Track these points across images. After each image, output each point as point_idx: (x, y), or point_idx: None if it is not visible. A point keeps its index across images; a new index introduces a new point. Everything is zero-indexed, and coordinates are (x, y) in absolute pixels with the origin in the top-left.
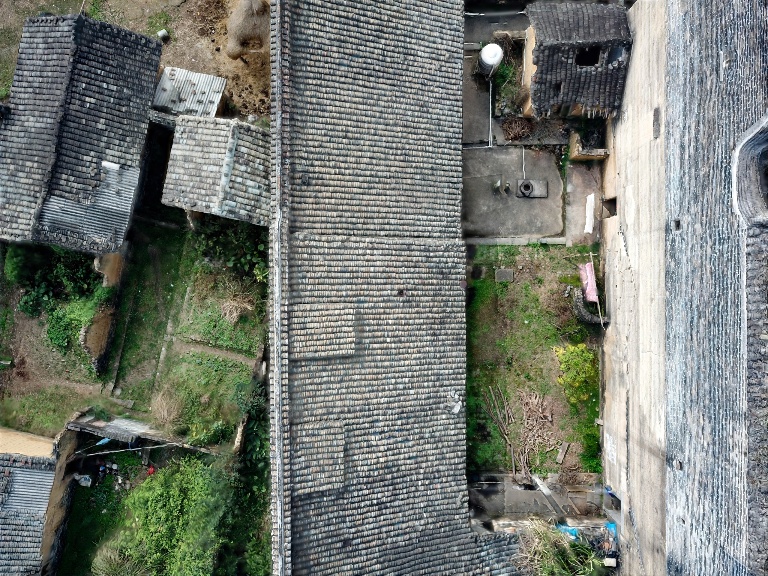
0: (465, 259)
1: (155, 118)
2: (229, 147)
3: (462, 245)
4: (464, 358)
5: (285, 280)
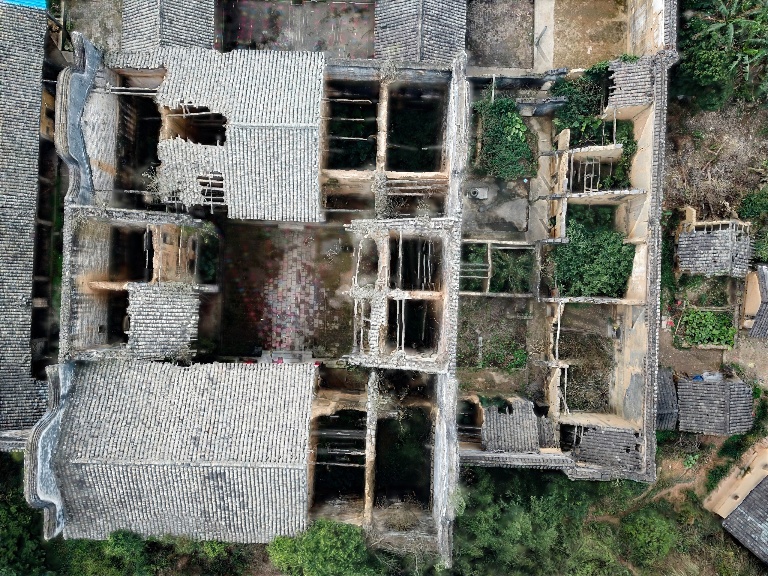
0: (34, 221)
1: None
2: None
3: (32, 213)
4: (31, 278)
5: None
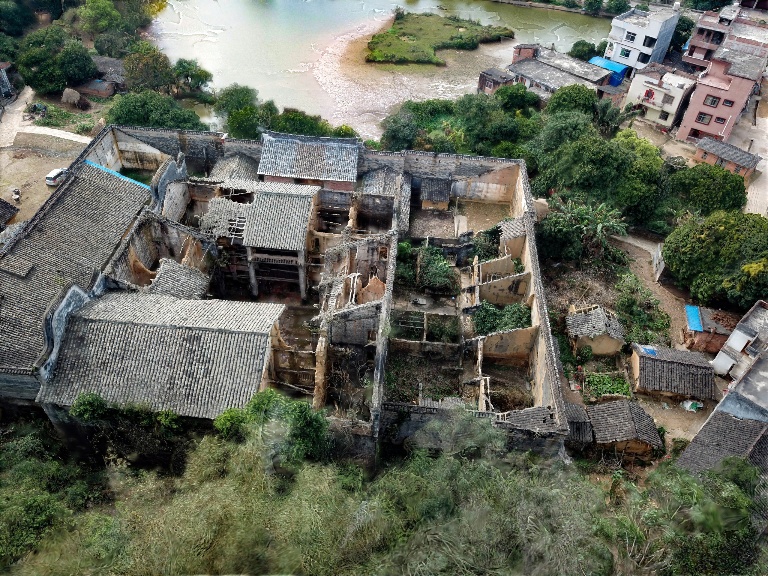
0: None
1: (2, 226)
2: (20, 225)
3: None
4: None
5: (10, 246)
